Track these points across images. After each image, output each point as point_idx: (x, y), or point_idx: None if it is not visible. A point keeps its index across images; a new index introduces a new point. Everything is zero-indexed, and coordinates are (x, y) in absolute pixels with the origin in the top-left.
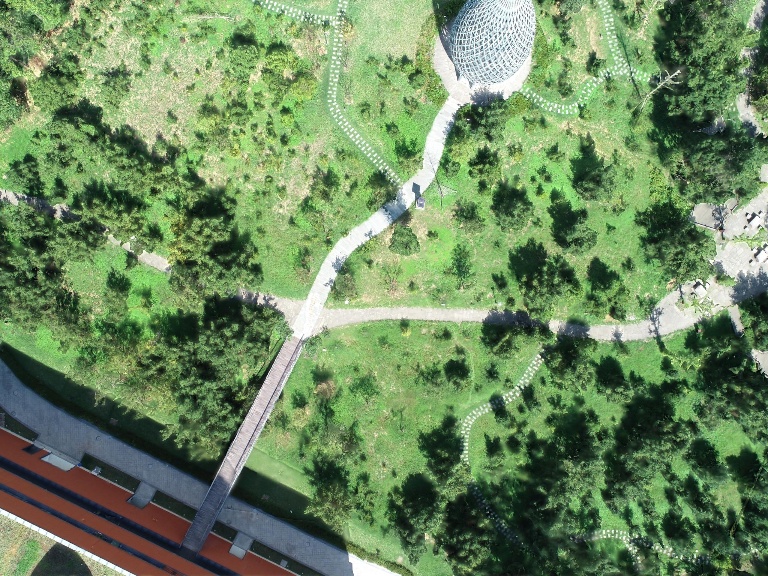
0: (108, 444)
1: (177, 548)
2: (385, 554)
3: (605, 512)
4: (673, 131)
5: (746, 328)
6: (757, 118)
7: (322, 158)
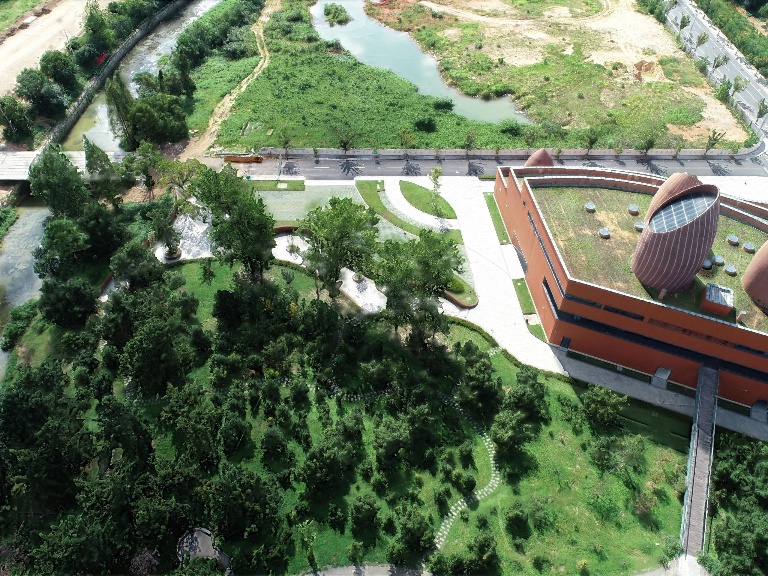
0: None
1: (722, 367)
2: (540, 377)
3: None
4: None
5: None
6: None
7: None
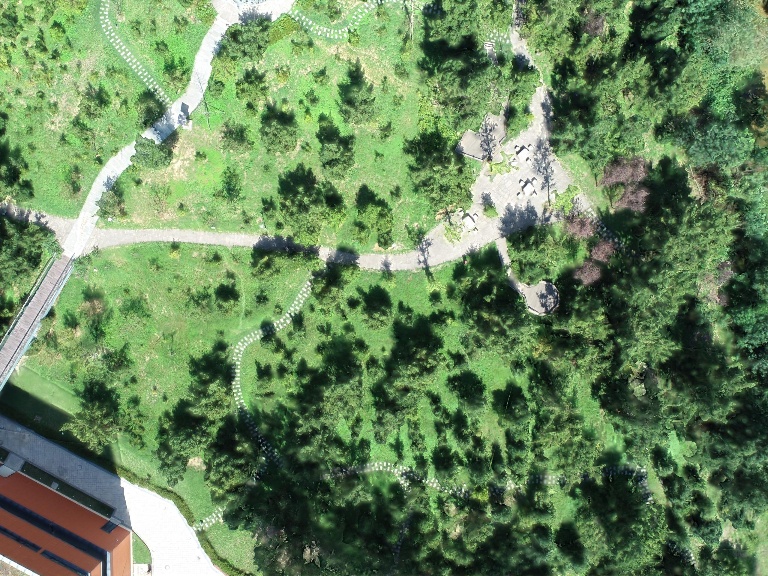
0: None
1: None
2: (156, 479)
3: (377, 444)
4: (444, 60)
5: (512, 261)
6: (530, 51)
7: (93, 75)
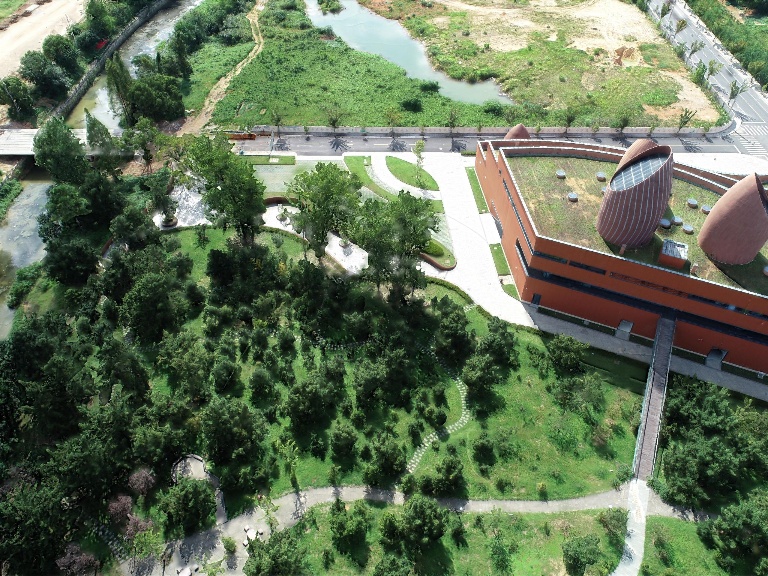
0: (763, 395)
1: (678, 318)
2: (512, 330)
3: None
4: None
5: None
6: None
7: None
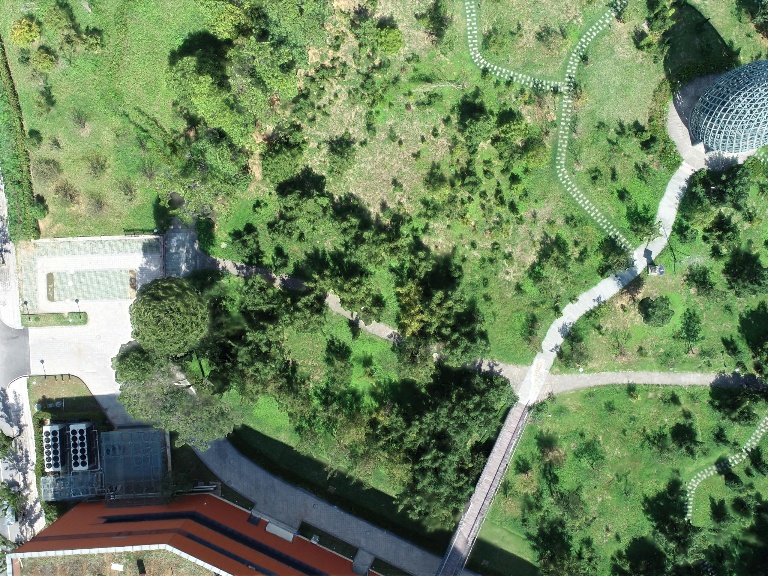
0: (325, 512)
1: None
2: None
3: None
4: None
5: None
6: None
7: (550, 224)
